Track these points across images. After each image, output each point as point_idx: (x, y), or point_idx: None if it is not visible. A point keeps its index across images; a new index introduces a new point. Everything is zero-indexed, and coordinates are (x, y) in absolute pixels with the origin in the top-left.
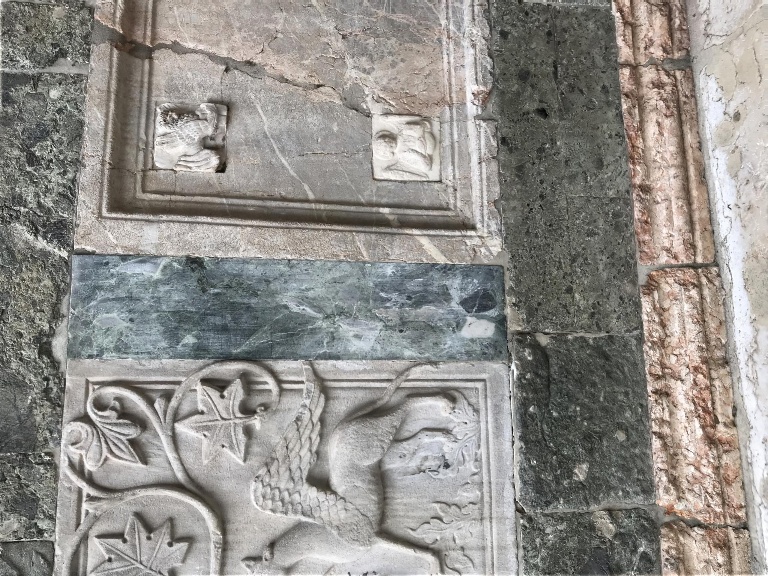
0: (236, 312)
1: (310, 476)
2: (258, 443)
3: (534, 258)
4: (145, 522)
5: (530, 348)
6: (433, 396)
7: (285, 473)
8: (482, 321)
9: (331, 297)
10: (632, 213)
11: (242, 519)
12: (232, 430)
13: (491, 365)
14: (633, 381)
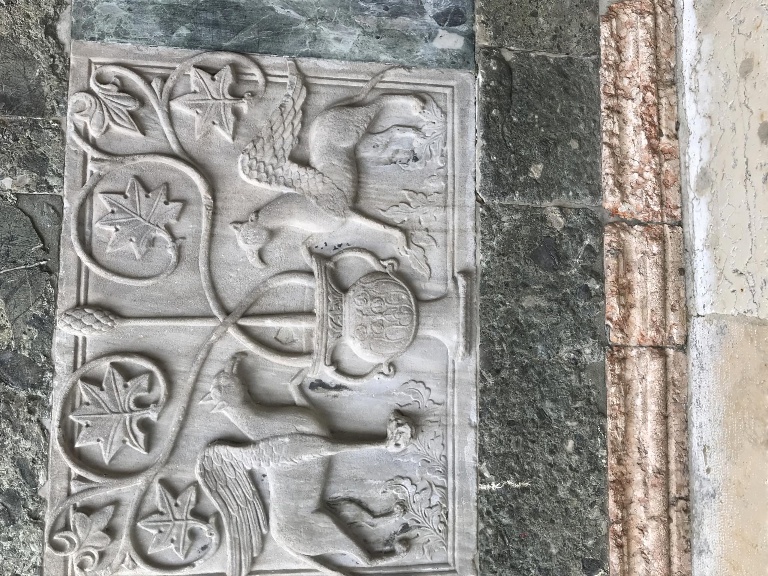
0: (226, 9)
1: (292, 157)
2: (245, 125)
3: None
4: (144, 184)
5: (495, 59)
6: (405, 95)
7: (269, 150)
8: (452, 34)
9: (314, 2)
10: None
11: (231, 189)
12: (222, 109)
13: (459, 74)
14: (588, 98)
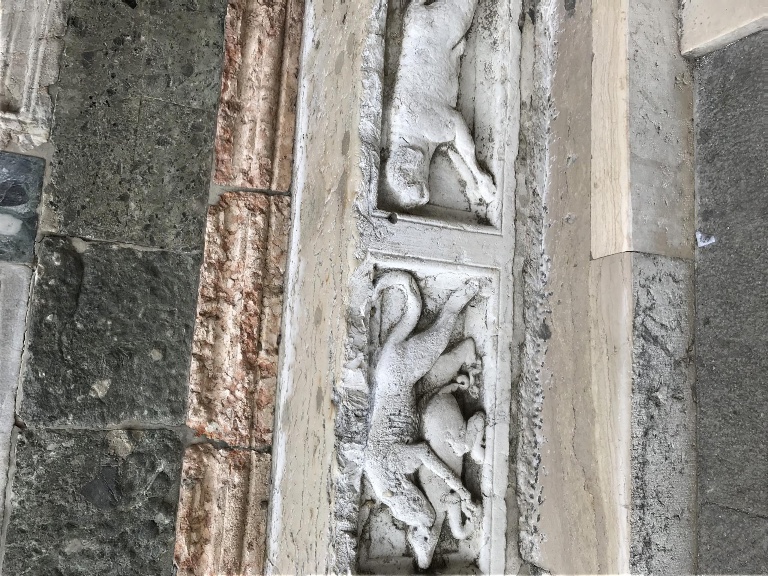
0: None
1: None
2: None
3: (87, 156)
4: None
5: (60, 252)
6: None
7: None
8: (6, 216)
9: None
10: (215, 129)
11: None
12: None
13: (10, 266)
14: (182, 301)
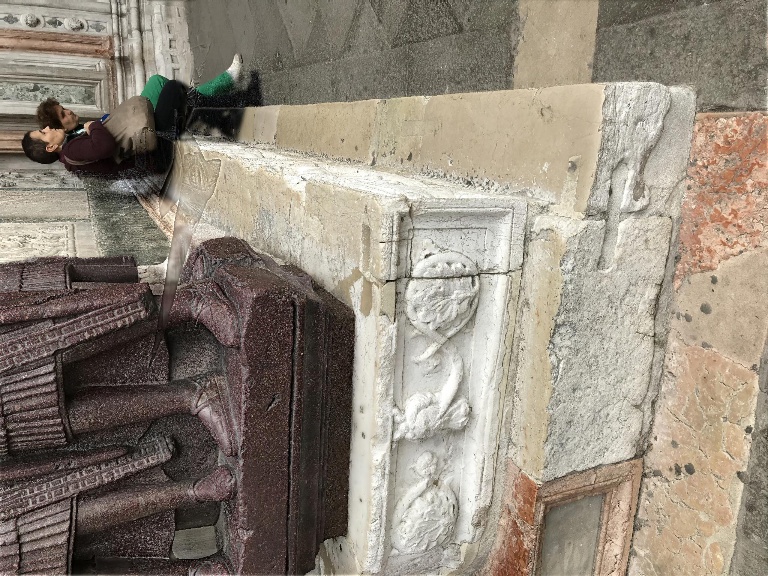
0: None
1: None
2: None
3: None
4: None
5: None
6: None
7: None
8: None
9: None
10: None
11: None
12: (6, 171)
13: None
14: None
